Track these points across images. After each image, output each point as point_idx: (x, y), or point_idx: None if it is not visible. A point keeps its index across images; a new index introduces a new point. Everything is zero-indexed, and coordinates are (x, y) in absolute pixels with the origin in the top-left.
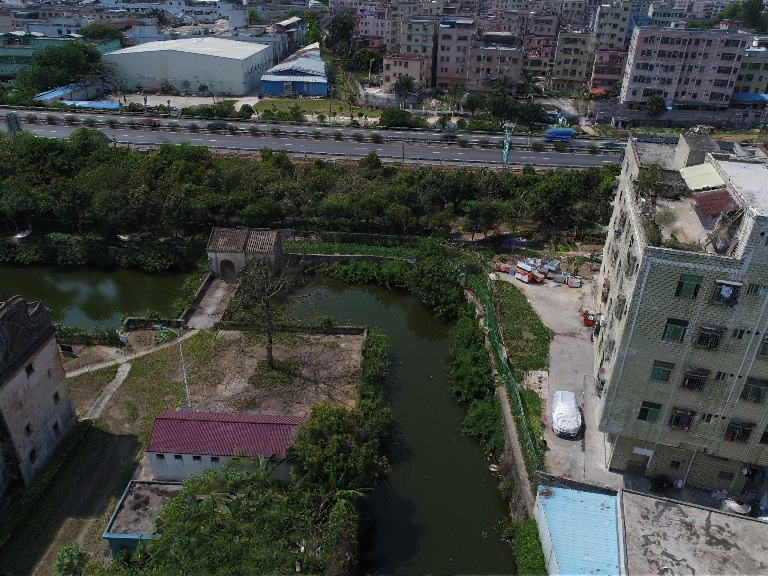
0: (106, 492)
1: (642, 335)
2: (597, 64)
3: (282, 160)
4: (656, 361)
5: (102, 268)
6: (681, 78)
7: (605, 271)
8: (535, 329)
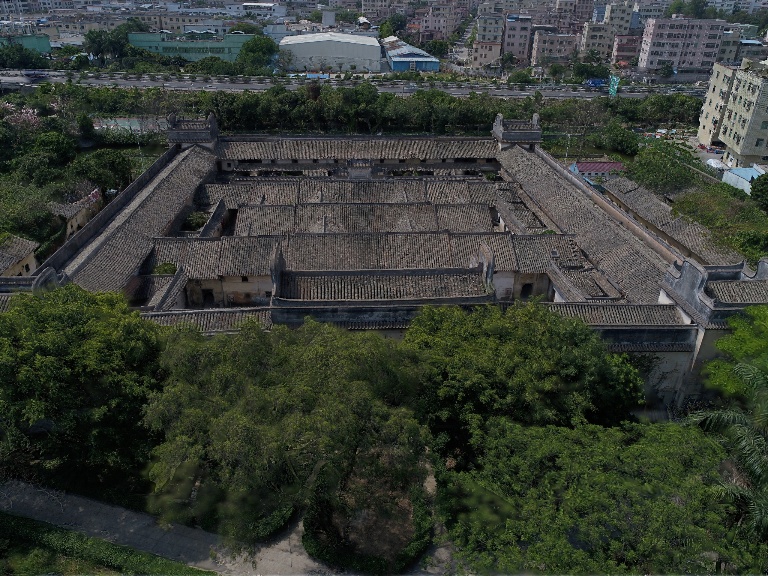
0: None
1: (759, 112)
2: (619, 45)
3: (486, 98)
4: (763, 121)
5: None
6: (682, 52)
7: (706, 126)
8: None
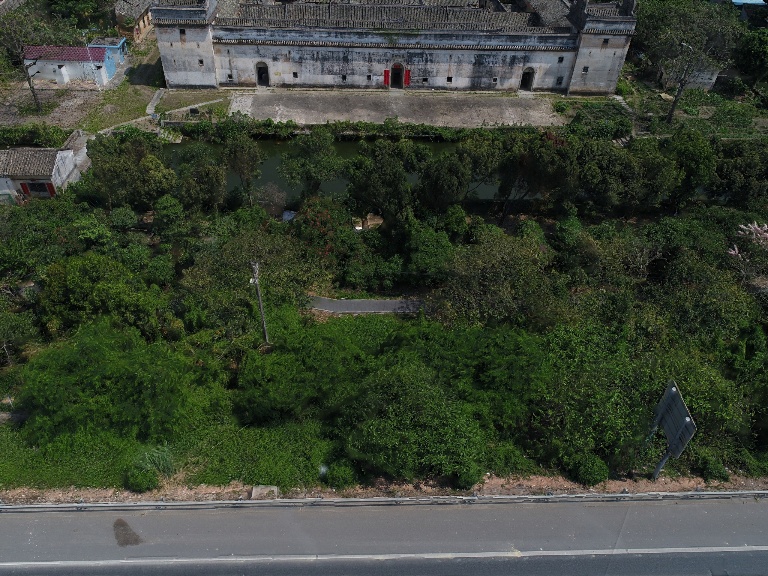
0: None
1: None
2: None
3: None
4: None
5: None
6: None
7: None
8: None
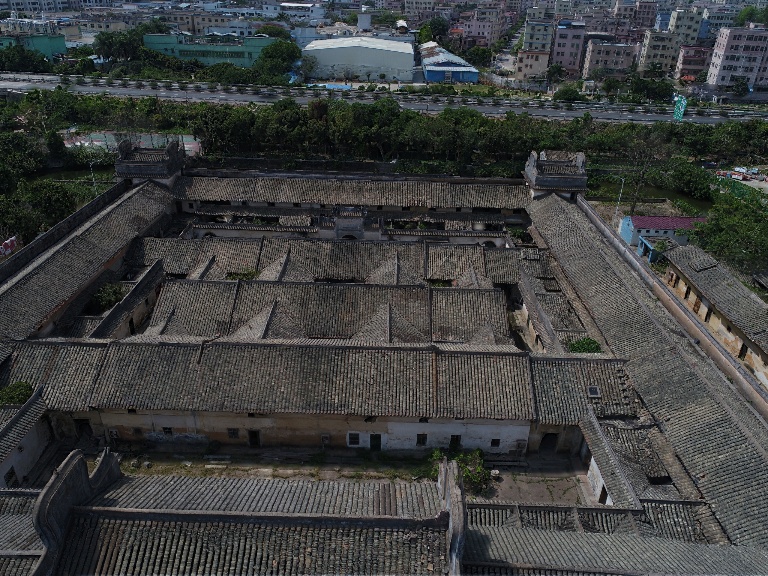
0: None
1: None
2: (685, 57)
3: (526, 119)
4: None
5: None
6: (760, 67)
7: None
8: (767, 197)
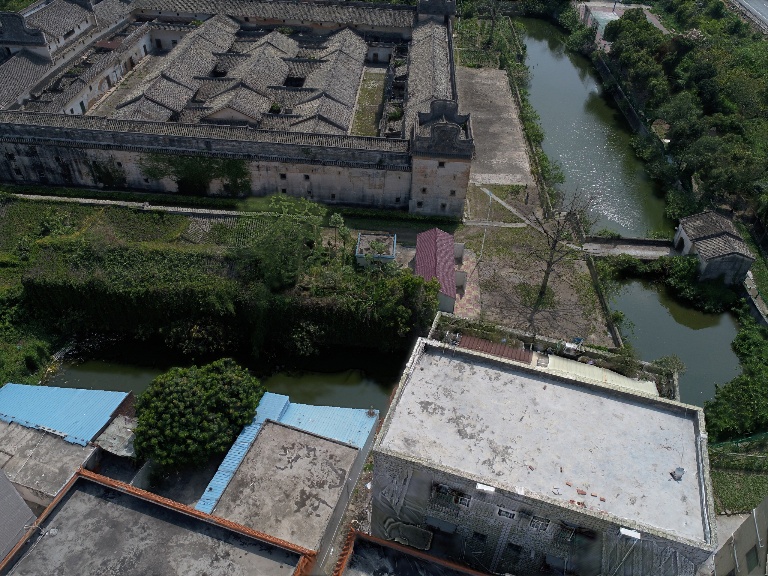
0: (407, 240)
1: None
2: None
3: None
4: None
5: (659, 190)
6: None
7: None
8: None
